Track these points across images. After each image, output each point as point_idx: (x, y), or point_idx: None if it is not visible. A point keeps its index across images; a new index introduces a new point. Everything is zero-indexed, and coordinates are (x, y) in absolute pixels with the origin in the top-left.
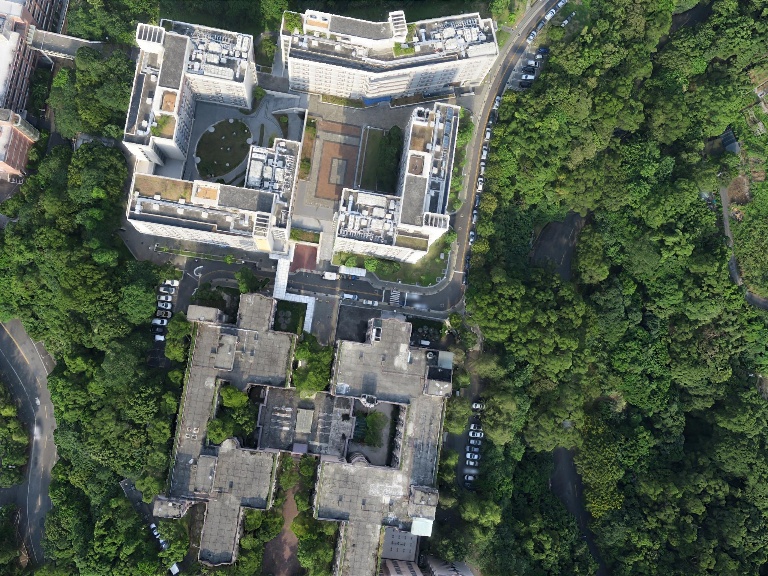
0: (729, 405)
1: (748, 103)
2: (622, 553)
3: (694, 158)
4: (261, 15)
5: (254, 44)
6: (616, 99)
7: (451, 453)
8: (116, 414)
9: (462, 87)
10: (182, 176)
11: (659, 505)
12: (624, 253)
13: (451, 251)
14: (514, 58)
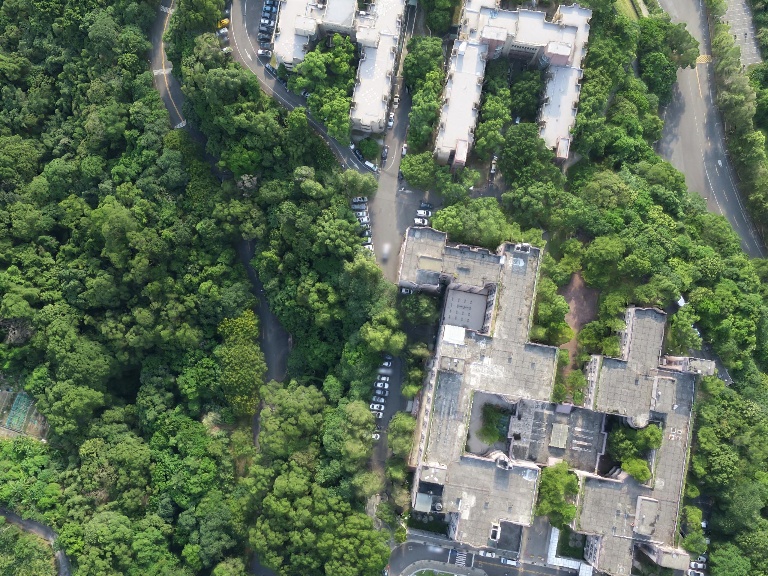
0: (88, 415)
1: None
2: (226, 274)
3: None
4: None
5: None
6: None
7: None
8: (744, 453)
9: None
10: None
11: (180, 317)
12: None
13: None
14: None
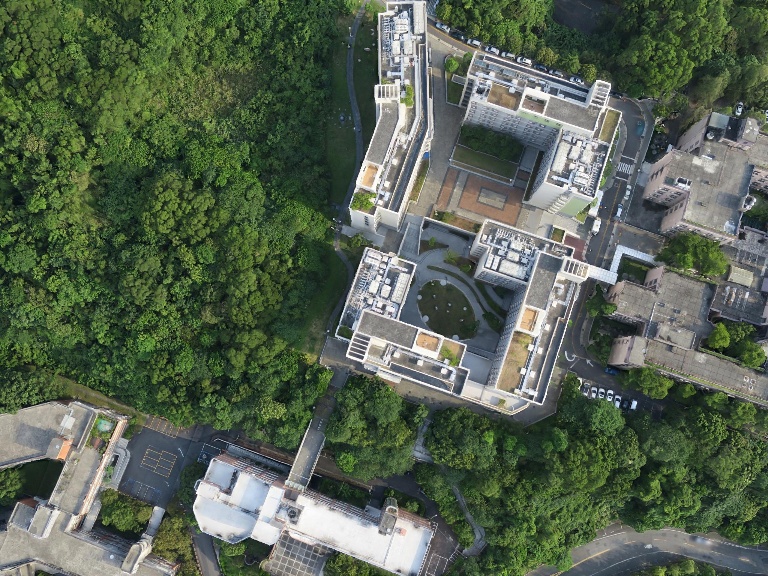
0: None
1: None
2: None
3: None
4: (324, 243)
5: (345, 259)
6: None
7: None
8: None
9: None
10: (475, 354)
11: None
12: None
13: None
14: None
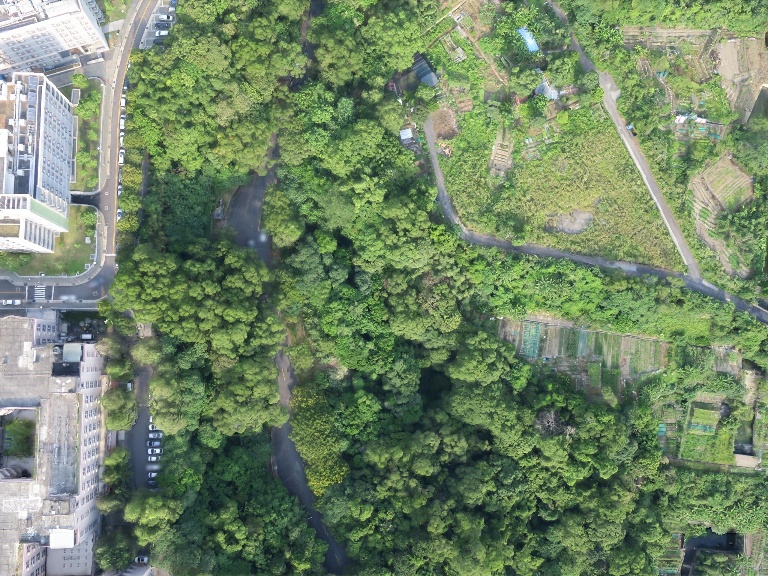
0: (460, 354)
1: (444, 29)
2: (350, 529)
3: (374, 96)
4: None
5: None
6: (254, 43)
7: (114, 452)
8: None
9: (88, 54)
10: None
11: (390, 472)
12: (318, 209)
13: (98, 233)
14: (145, 15)
